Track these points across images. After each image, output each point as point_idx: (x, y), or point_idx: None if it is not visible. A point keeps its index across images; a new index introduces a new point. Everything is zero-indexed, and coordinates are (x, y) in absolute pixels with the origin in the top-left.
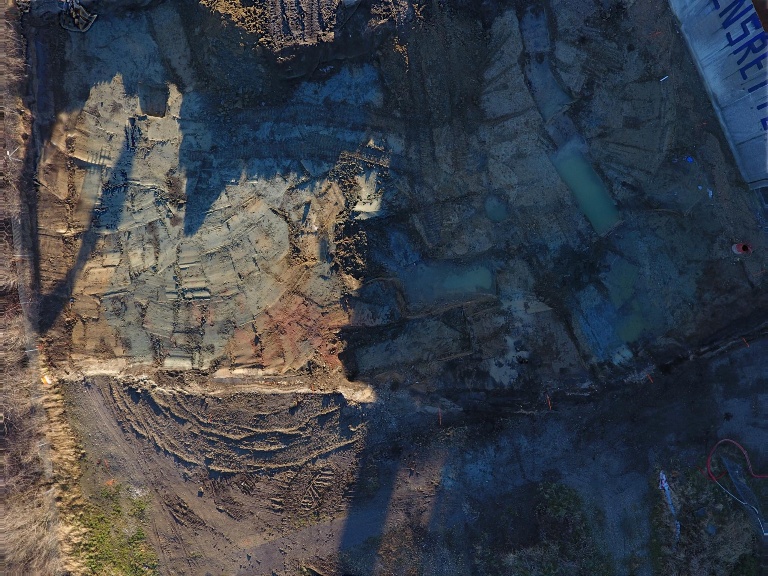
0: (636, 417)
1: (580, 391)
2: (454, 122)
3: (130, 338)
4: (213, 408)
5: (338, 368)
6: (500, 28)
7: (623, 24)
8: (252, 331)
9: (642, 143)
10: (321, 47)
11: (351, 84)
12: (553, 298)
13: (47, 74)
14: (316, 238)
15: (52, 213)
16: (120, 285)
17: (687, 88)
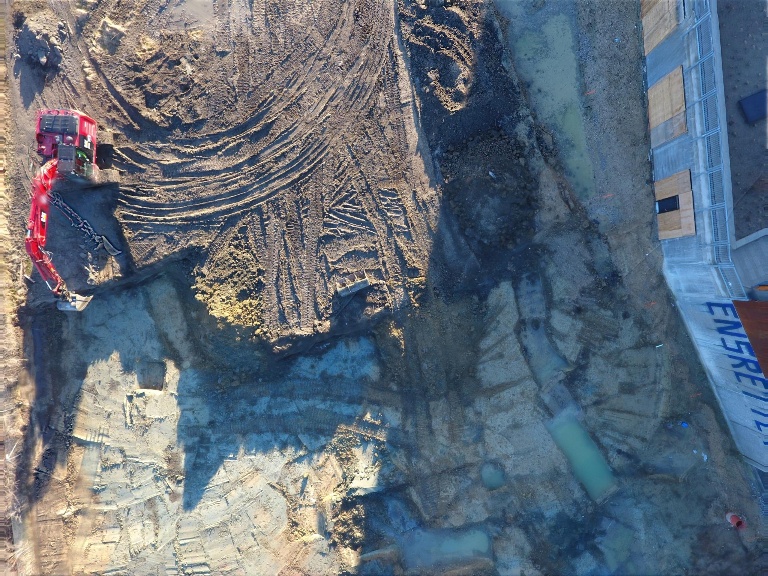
0: None
1: None
2: (450, 394)
3: None
4: None
5: None
6: (496, 299)
7: (618, 291)
8: None
9: (637, 408)
10: (317, 335)
11: (347, 358)
12: (549, 569)
13: (44, 358)
14: (314, 510)
15: (52, 496)
16: (120, 563)
17: (682, 359)
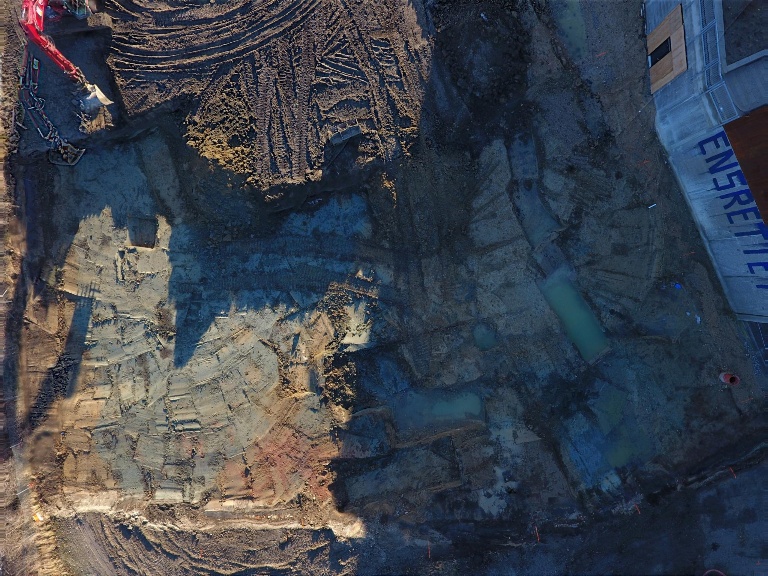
0: (624, 549)
1: (568, 522)
2: (442, 252)
3: (121, 471)
4: (204, 544)
5: (328, 501)
6: (488, 157)
7: (611, 151)
8: (242, 463)
9: (630, 270)
10: (309, 185)
11: (340, 215)
12: (541, 428)
13: (36, 210)
14: (305, 368)
15: (42, 349)
16: (111, 418)
17: (675, 217)
